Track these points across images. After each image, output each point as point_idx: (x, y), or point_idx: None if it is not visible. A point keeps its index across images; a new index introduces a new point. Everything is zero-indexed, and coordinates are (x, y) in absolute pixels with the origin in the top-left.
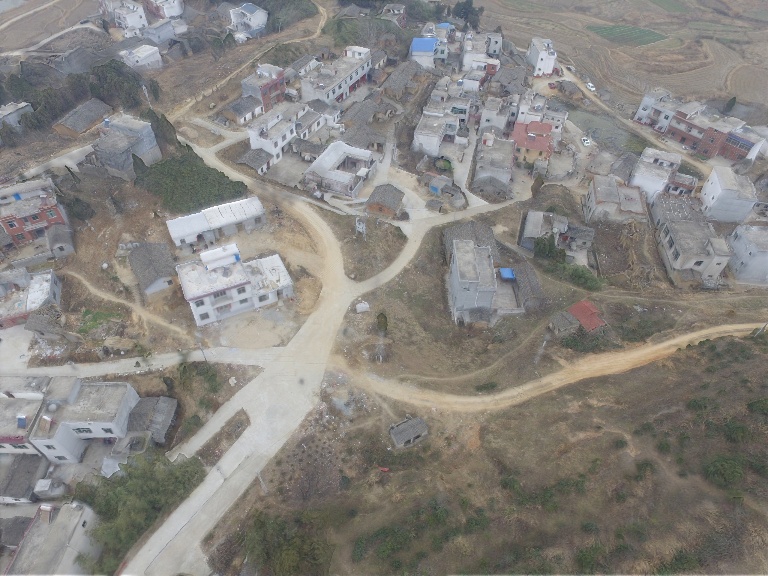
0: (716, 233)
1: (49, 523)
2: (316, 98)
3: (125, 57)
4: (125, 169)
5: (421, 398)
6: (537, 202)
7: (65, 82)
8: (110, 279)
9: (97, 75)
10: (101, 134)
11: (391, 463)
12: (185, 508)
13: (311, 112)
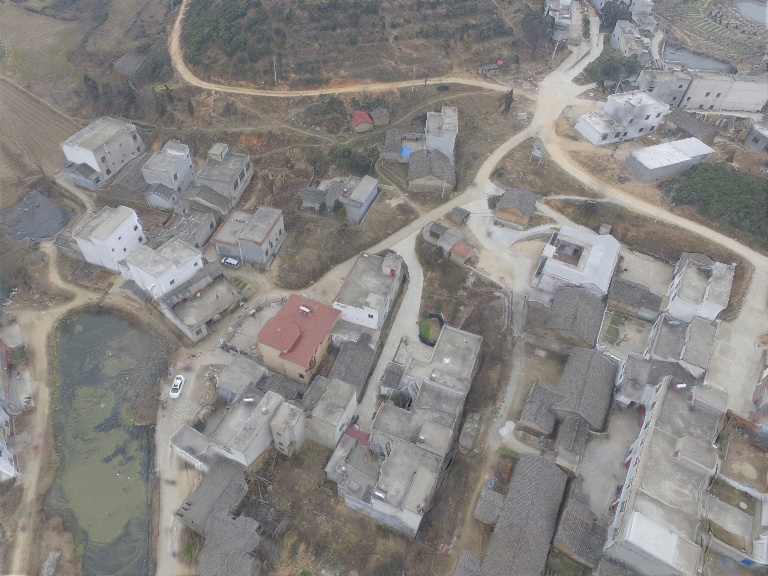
0: (158, 221)
1: None
2: None
3: None
4: None
5: (481, 84)
6: (337, 238)
7: None
8: None
9: None
10: None
11: None
12: None
13: None
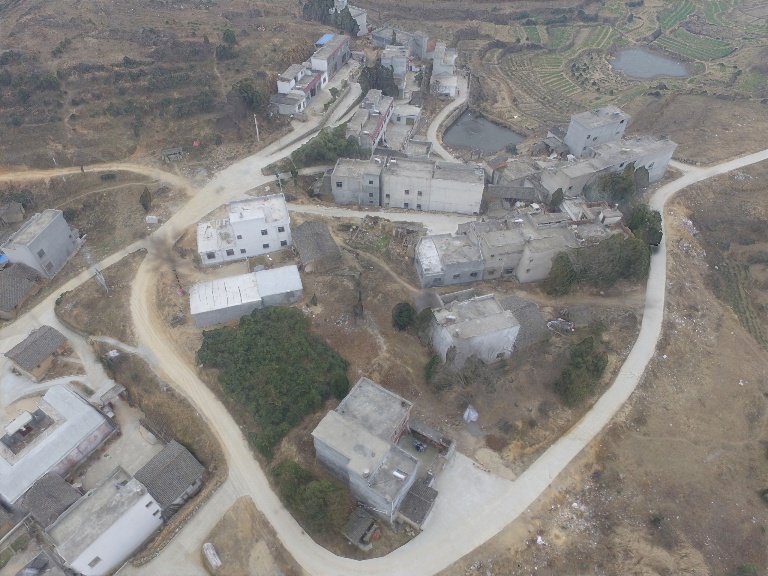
0: None
1: None
2: None
3: None
4: None
5: (153, 172)
6: None
7: None
8: (365, 263)
9: None
10: None
11: (190, 148)
12: None
13: None
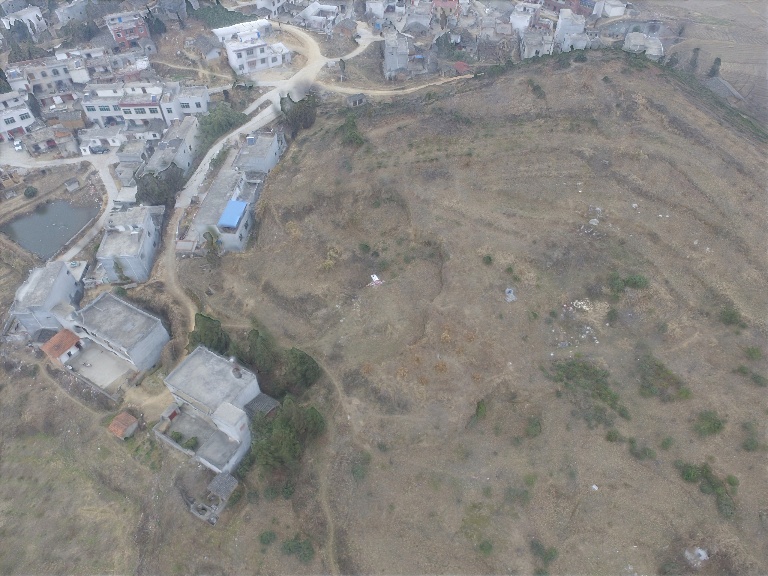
0: None
1: (179, 126)
2: None
3: None
4: (180, 12)
5: None
6: None
7: None
8: (182, 59)
9: None
10: None
11: None
12: (243, 128)
13: None
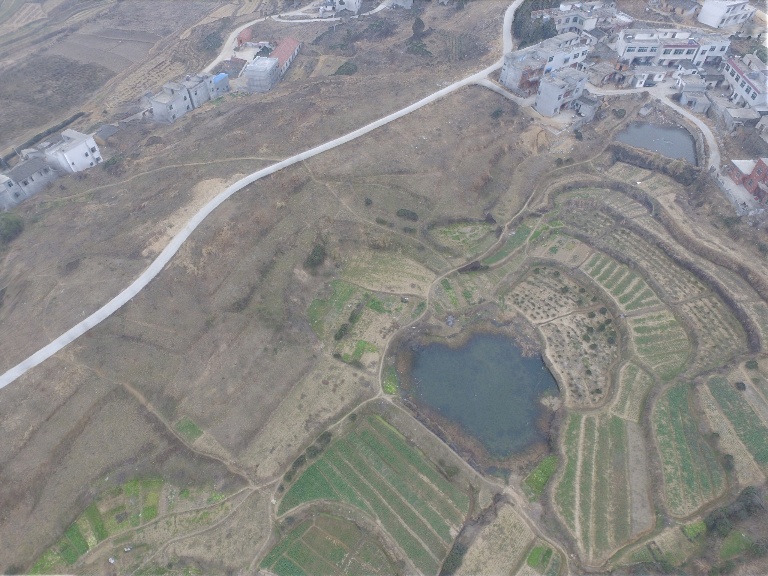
0: None
1: (738, 63)
2: None
3: None
4: None
5: None
6: None
7: None
8: (652, 15)
9: None
10: None
11: None
12: None
13: None
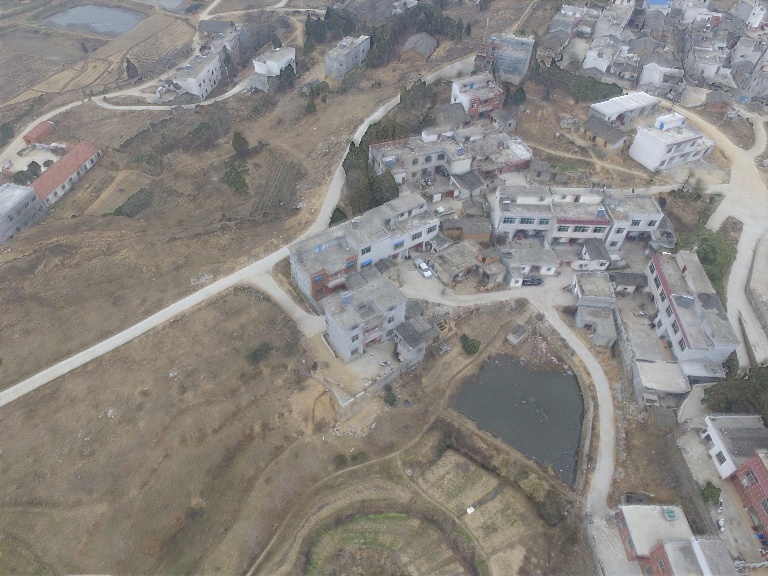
0: None
1: (668, 264)
2: (608, 34)
3: (399, 7)
4: (520, 74)
5: None
6: None
7: (389, 21)
8: (563, 144)
9: (425, 13)
10: (489, 49)
11: None
12: (738, 264)
13: (610, 44)
